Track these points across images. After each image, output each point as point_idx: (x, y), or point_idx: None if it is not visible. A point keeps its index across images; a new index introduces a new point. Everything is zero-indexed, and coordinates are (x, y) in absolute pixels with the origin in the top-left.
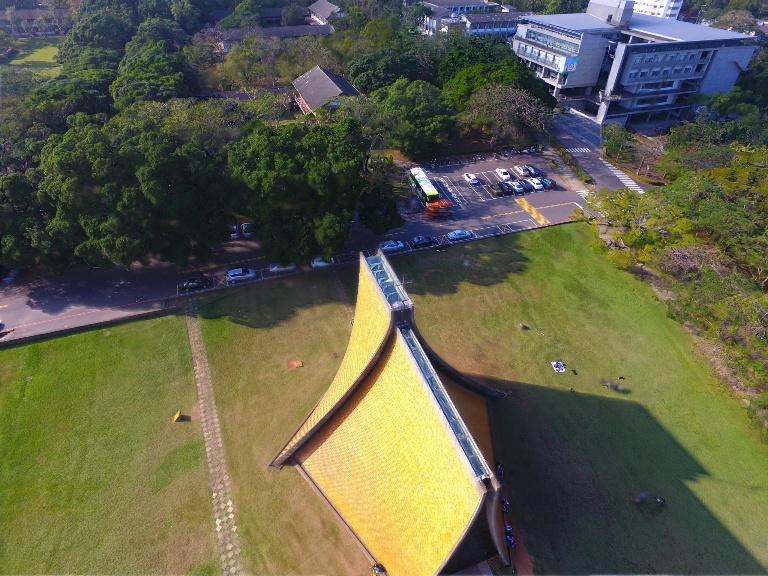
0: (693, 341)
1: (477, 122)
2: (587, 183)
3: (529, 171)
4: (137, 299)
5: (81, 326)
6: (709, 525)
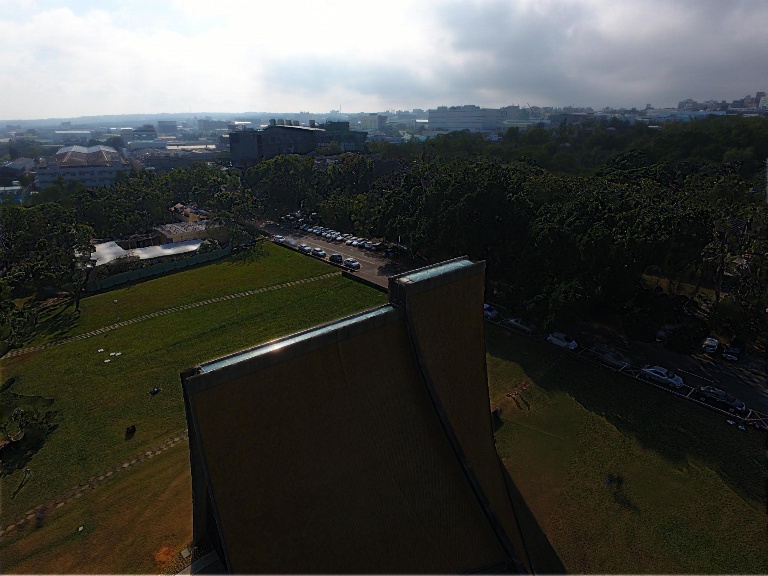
0: None
1: None
2: None
3: None
4: None
5: (376, 284)
6: None
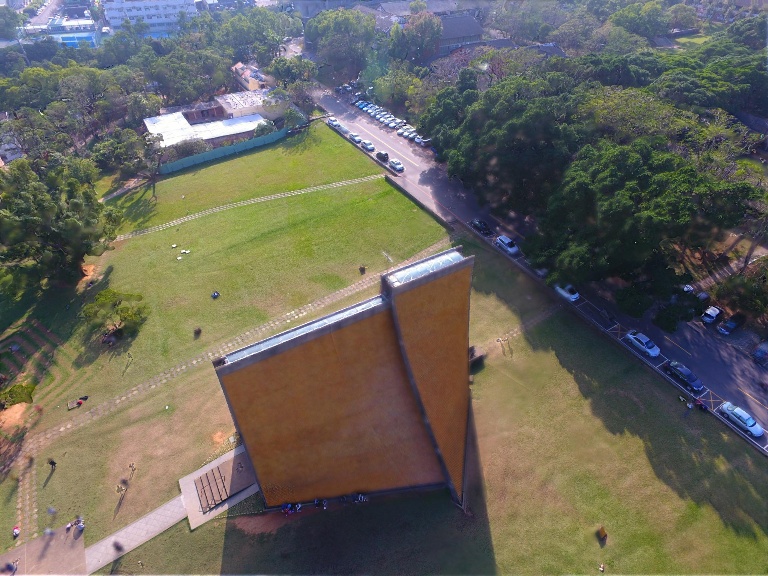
0: None
1: None
2: None
3: None
4: (451, 208)
5: (414, 197)
6: None
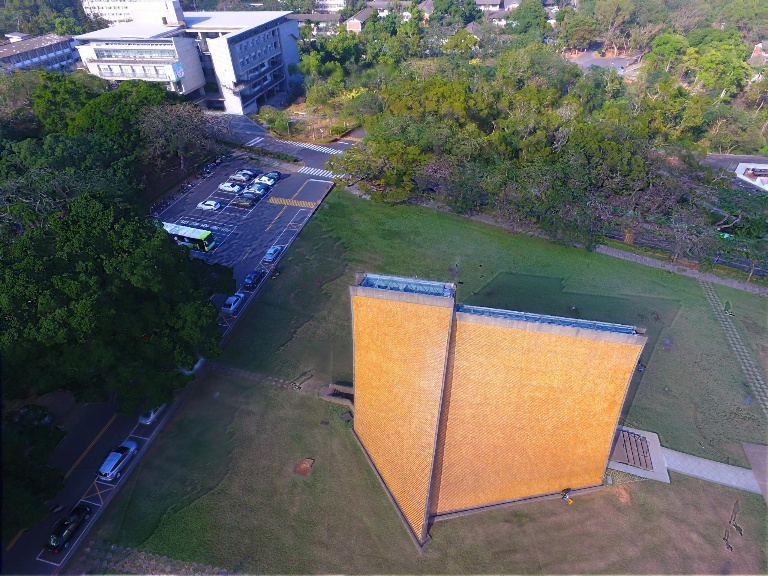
0: (475, 220)
1: (172, 149)
2: (296, 162)
3: (247, 174)
4: None
5: None
6: (594, 300)
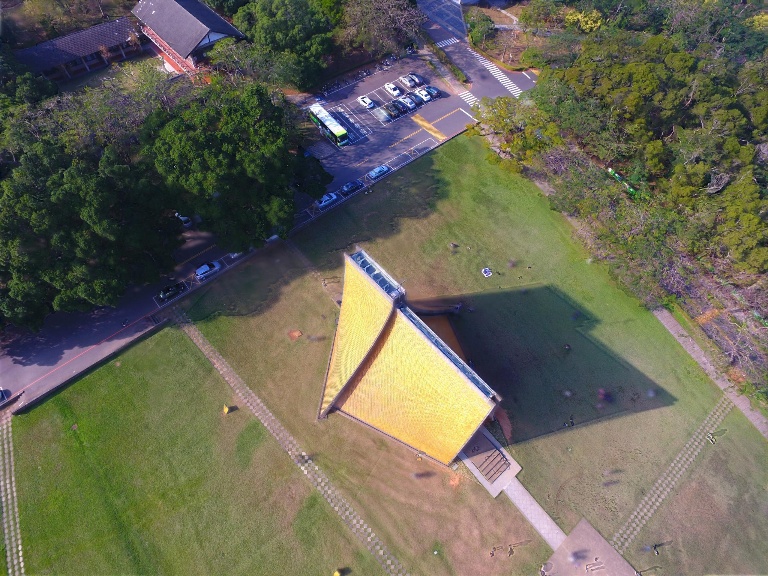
0: (568, 222)
1: (358, 42)
2: (465, 83)
3: (414, 81)
4: (123, 323)
5: (89, 366)
6: (595, 352)
